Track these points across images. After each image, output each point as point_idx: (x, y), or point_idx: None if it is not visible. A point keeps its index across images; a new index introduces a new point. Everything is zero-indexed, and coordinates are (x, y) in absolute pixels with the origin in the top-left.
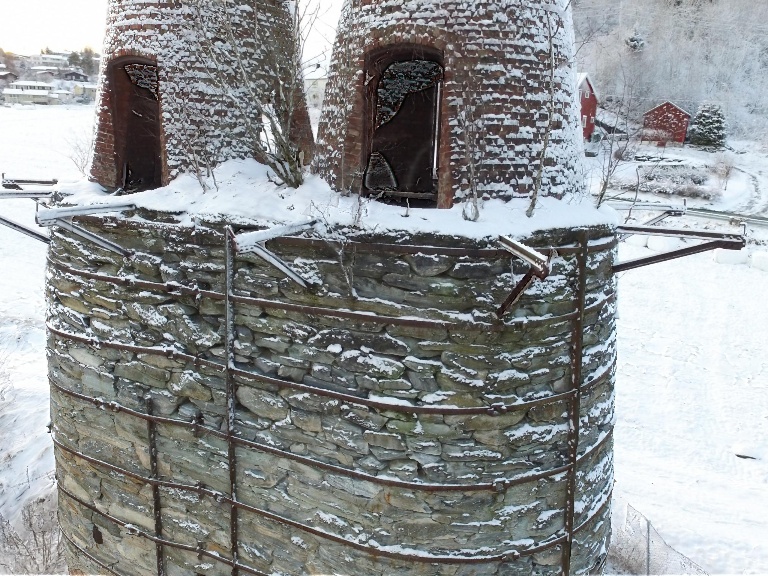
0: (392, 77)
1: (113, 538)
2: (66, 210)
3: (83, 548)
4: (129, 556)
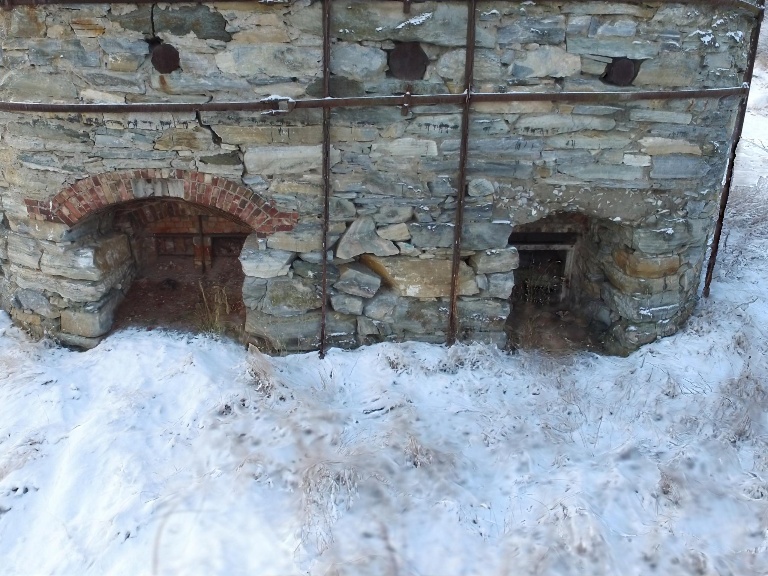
0: None
1: (209, 44)
2: None
3: (120, 102)
4: (246, 68)
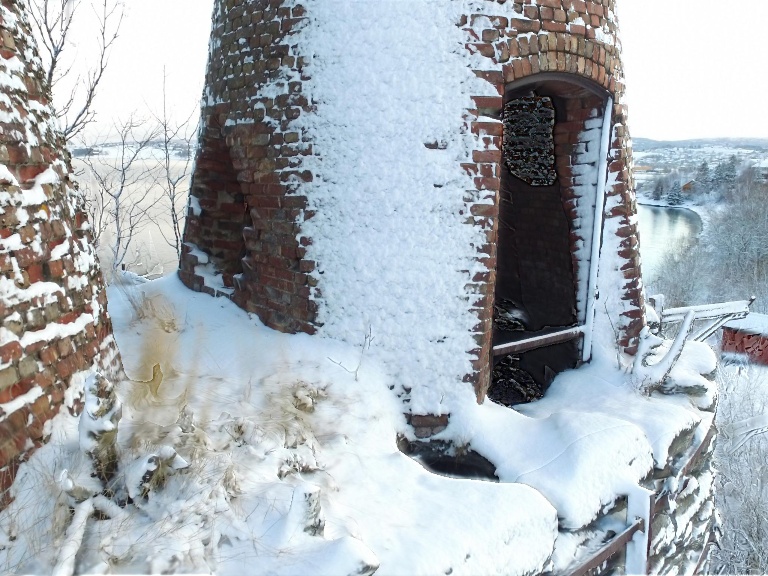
0: (5, 41)
1: None
2: None
3: None
4: None
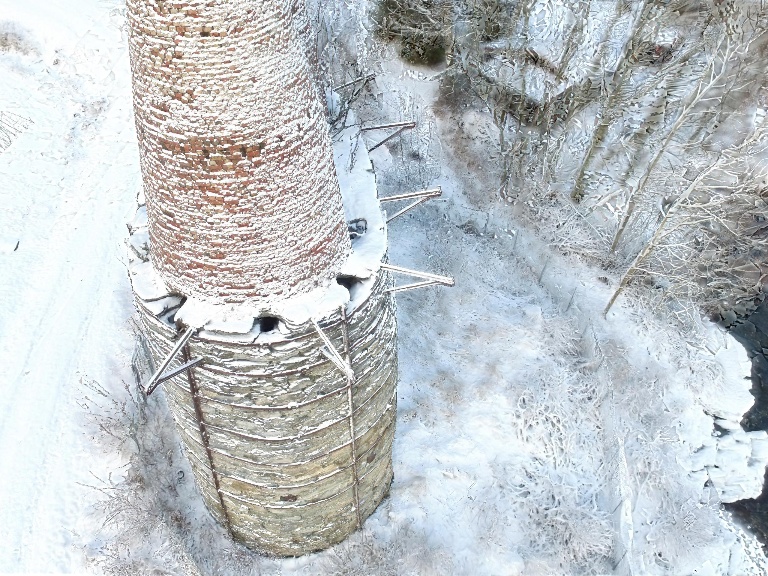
0: None
1: None
2: (425, 192)
3: None
4: None
